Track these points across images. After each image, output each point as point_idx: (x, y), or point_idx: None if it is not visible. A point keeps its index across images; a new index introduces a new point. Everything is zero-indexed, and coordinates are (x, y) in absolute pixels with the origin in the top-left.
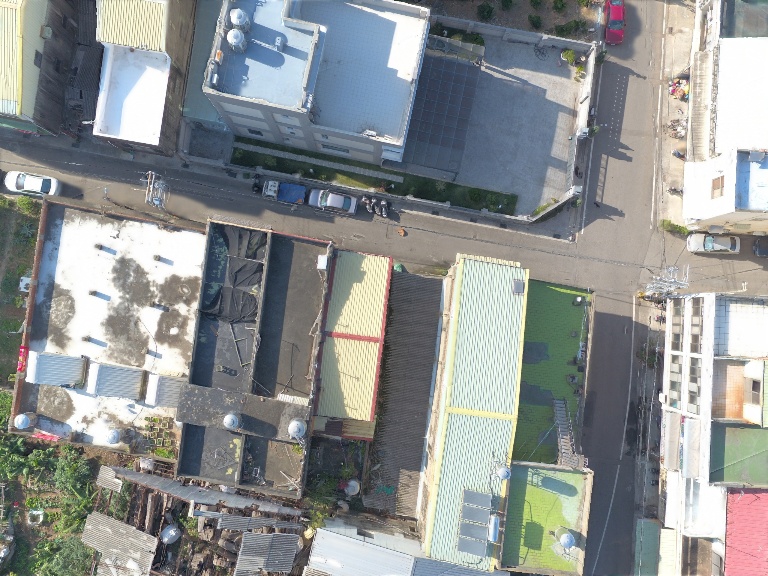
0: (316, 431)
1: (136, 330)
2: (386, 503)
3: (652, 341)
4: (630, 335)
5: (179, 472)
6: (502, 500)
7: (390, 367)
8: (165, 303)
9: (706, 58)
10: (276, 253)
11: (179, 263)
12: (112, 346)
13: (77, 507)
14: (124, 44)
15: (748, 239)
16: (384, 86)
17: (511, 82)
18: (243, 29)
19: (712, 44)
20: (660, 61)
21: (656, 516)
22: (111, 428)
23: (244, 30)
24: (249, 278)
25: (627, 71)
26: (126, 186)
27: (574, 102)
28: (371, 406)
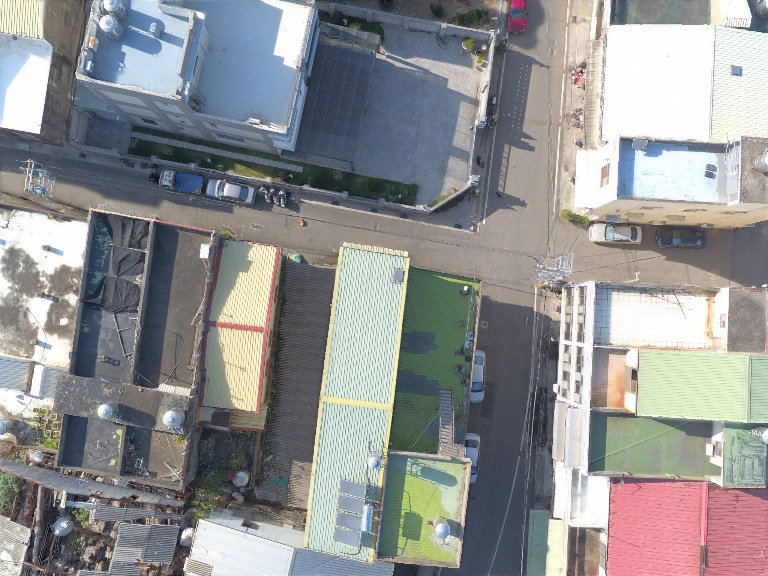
0: (202, 422)
1: (25, 321)
2: (278, 494)
3: (553, 331)
4: (531, 326)
5: (60, 463)
6: (379, 490)
7: (283, 358)
8: (55, 293)
9: (598, 46)
10: (160, 242)
11: (69, 253)
12: (1, 337)
13: None
14: (1, 31)
15: (651, 229)
16: (270, 74)
17: (412, 71)
18: (118, 15)
19: (604, 32)
20: (564, 50)
21: (550, 507)
22: None
23: (119, 16)
24: (133, 268)
25: (530, 60)
26: (22, 176)
27: (476, 91)
28: (257, 396)
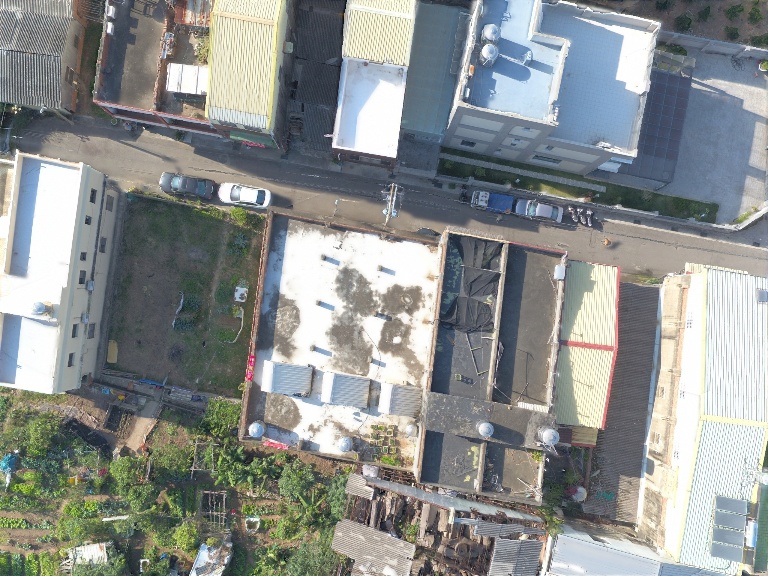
0: None
1: (360, 339)
2: (606, 509)
3: None
4: None
5: None
6: (753, 506)
7: None
8: (388, 312)
9: None
10: (510, 263)
11: (401, 273)
12: (337, 355)
13: (301, 514)
14: (369, 59)
15: None
16: (613, 98)
17: (709, 93)
18: (493, 44)
19: None
20: None
21: None
22: (337, 436)
23: None
24: (484, 288)
25: None
26: (334, 197)
27: None
28: (603, 413)
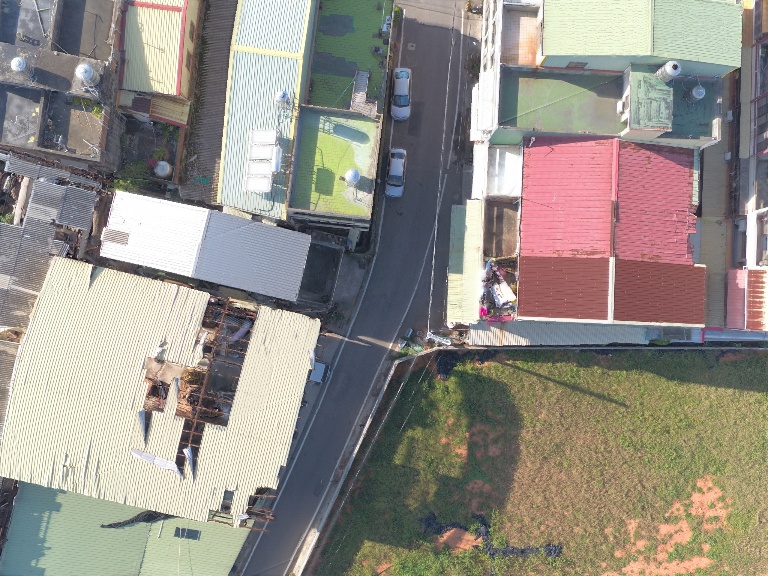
0: None
1: None
2: (202, 193)
3: (479, 52)
4: (458, 48)
5: None
6: (291, 142)
7: (207, 61)
8: None
9: None
10: None
11: None
12: None
13: None
14: None
15: None
16: None
17: None
18: None
19: None
20: None
21: None
22: None
23: None
24: None
25: None
26: None
27: None
28: (176, 79)
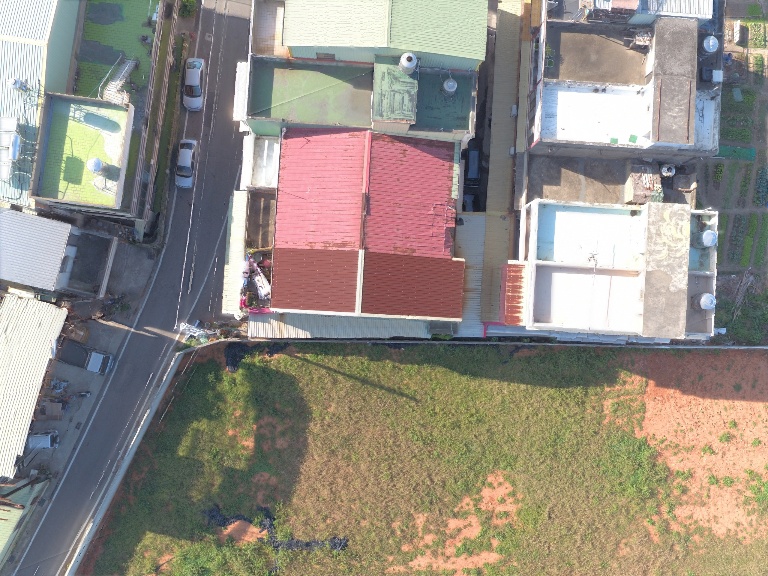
0: None
1: None
2: None
3: None
4: None
5: None
6: (37, 130)
7: None
8: None
9: None
10: None
11: None
12: None
13: None
14: None
15: None
16: None
17: None
18: None
19: None
20: None
21: None
22: None
23: None
24: None
25: None
26: None
27: None
28: None
